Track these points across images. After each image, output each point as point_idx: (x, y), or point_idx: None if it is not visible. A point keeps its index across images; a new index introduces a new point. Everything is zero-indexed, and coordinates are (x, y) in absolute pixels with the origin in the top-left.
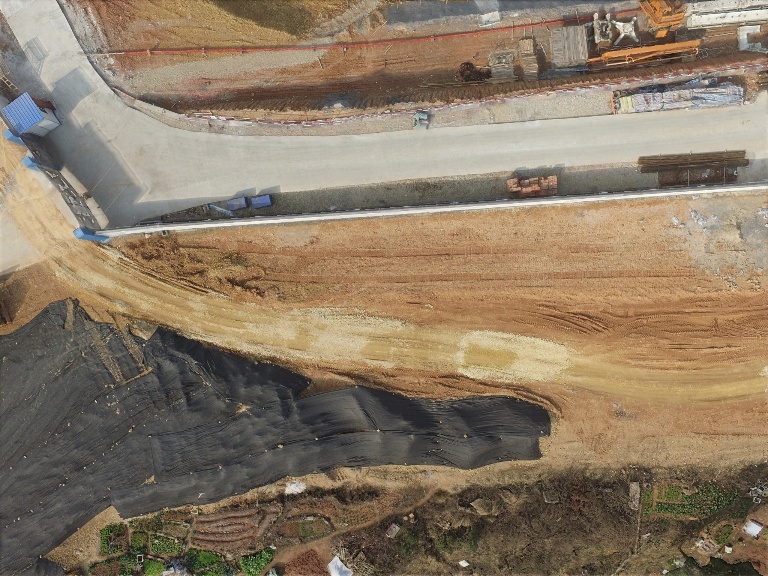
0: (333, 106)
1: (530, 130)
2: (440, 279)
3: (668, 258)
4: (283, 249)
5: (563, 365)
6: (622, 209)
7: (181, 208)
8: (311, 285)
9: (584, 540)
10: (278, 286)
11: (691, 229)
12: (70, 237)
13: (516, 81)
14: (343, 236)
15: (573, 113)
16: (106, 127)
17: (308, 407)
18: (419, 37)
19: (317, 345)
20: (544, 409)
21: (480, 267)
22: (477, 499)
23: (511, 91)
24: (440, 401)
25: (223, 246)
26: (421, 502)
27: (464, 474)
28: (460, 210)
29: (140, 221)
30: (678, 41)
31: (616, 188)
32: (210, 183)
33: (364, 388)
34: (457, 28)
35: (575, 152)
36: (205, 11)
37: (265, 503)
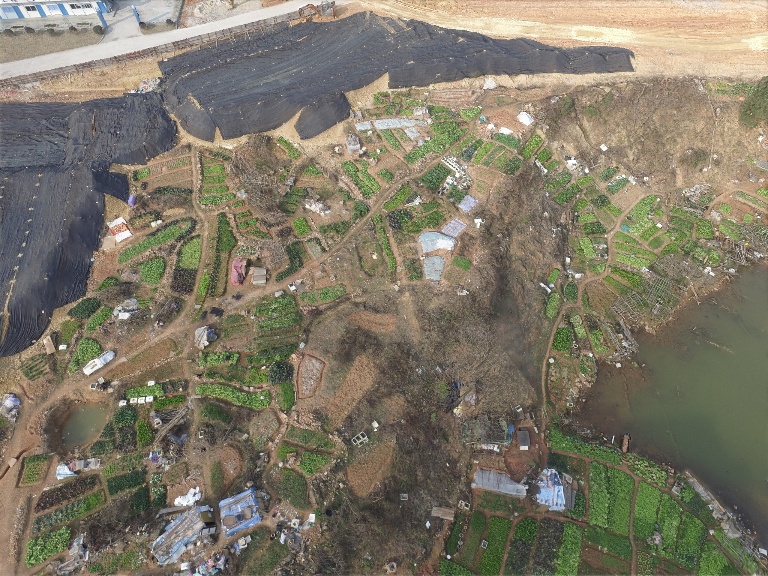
0: None
1: None
2: None
3: (667, 3)
4: None
5: (630, 37)
6: None
7: None
8: (490, 8)
9: None
10: None
11: None
12: None
13: None
14: None
15: None
16: None
17: None
18: None
19: (495, 29)
20: None
21: (574, 4)
22: None
23: None
24: (567, 48)
25: None
26: (568, 92)
27: (591, 77)
28: None
29: None
30: None
31: None
32: None
33: None
34: None
35: None
36: None
37: None
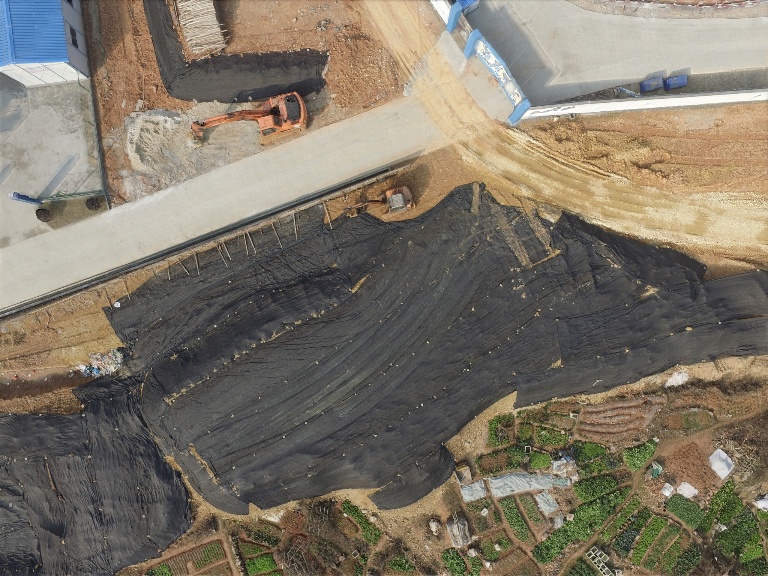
0: None
1: None
2: None
3: None
4: (687, 132)
5: None
6: None
7: (592, 90)
8: (715, 168)
9: None
10: (682, 169)
11: None
12: (478, 121)
13: None
14: (747, 119)
15: None
16: (521, 10)
17: (711, 291)
18: None
19: (714, 230)
20: None
21: None
22: None
23: None
24: None
25: (627, 130)
26: None
27: None
28: None
29: None
30: None
31: None
32: (621, 65)
33: (765, 272)
34: None
35: None
36: None
37: (650, 394)
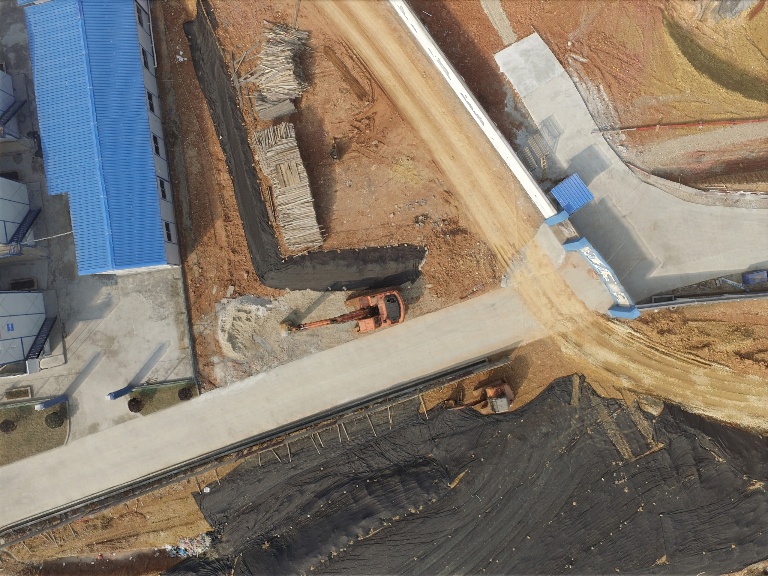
0: None
1: None
2: None
3: None
4: None
5: None
6: None
7: (693, 282)
8: None
9: None
10: None
11: None
12: (578, 312)
13: None
14: None
15: None
16: (621, 202)
17: None
18: None
19: None
20: None
21: None
22: None
23: None
24: None
25: (729, 319)
26: None
27: None
28: None
29: (653, 295)
30: None
31: None
32: (723, 256)
33: None
34: None
35: None
36: (702, 85)
37: None
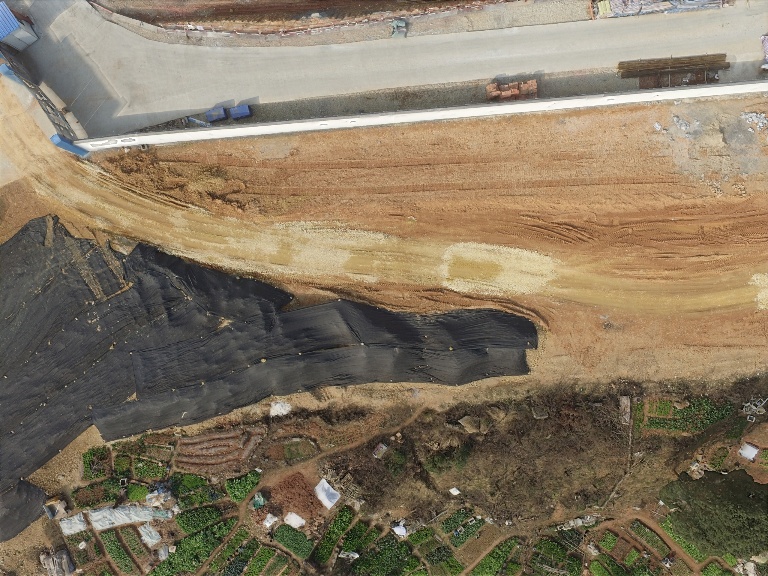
0: (311, 16)
1: (509, 37)
2: (422, 189)
3: (651, 164)
4: (263, 162)
5: (549, 276)
6: (604, 116)
7: (160, 121)
8: (292, 197)
9: (575, 457)
10: (259, 199)
11: (674, 135)
12: (49, 153)
13: None
14: (323, 147)
15: (552, 19)
16: (84, 41)
17: (291, 321)
18: None
19: (299, 260)
20: (530, 322)
21: (462, 176)
22: (465, 416)
23: None
24: (425, 315)
25: (203, 160)
26: (408, 422)
27: (451, 391)
28: (440, 119)
29: None
30: None
31: None
32: (189, 95)
33: (347, 301)
34: None
35: (555, 58)
36: None
37: (250, 424)
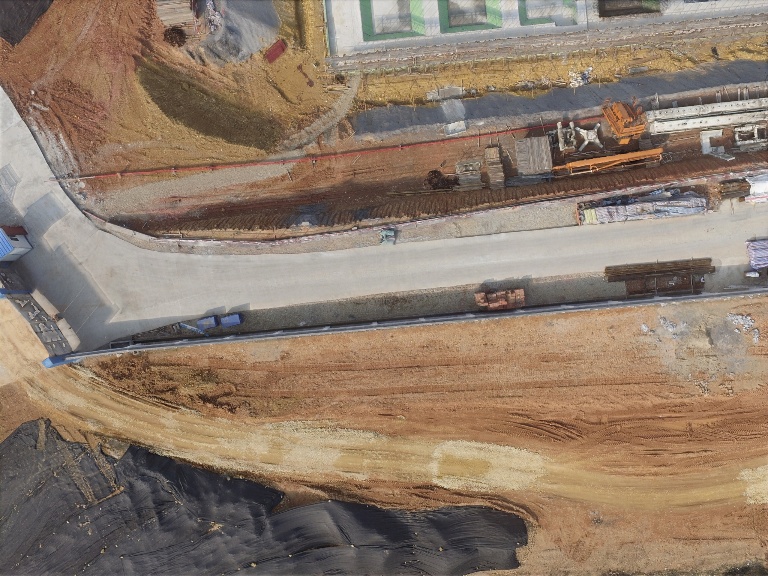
0: (301, 224)
1: (496, 243)
2: (411, 391)
3: (639, 365)
4: (254, 365)
5: (538, 473)
6: (591, 317)
7: (152, 327)
8: (282, 400)
9: None
10: (249, 402)
11: (661, 336)
12: (42, 358)
13: (483, 188)
14: (313, 351)
15: (539, 225)
16: (77, 250)
17: (281, 523)
18: (387, 147)
19: (290, 458)
20: (520, 518)
21: (451, 378)
22: None
23: (477, 204)
24: (415, 512)
25: (194, 363)
26: None
27: None
28: None
29: (111, 341)
30: (642, 146)
31: (584, 297)
32: (180, 302)
33: (337, 502)
34: (424, 137)
35: (542, 263)
36: (175, 132)
37: None
